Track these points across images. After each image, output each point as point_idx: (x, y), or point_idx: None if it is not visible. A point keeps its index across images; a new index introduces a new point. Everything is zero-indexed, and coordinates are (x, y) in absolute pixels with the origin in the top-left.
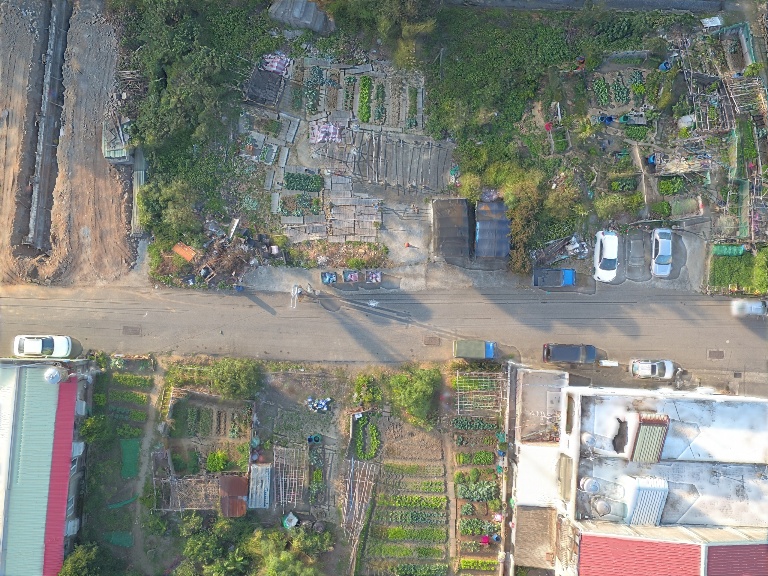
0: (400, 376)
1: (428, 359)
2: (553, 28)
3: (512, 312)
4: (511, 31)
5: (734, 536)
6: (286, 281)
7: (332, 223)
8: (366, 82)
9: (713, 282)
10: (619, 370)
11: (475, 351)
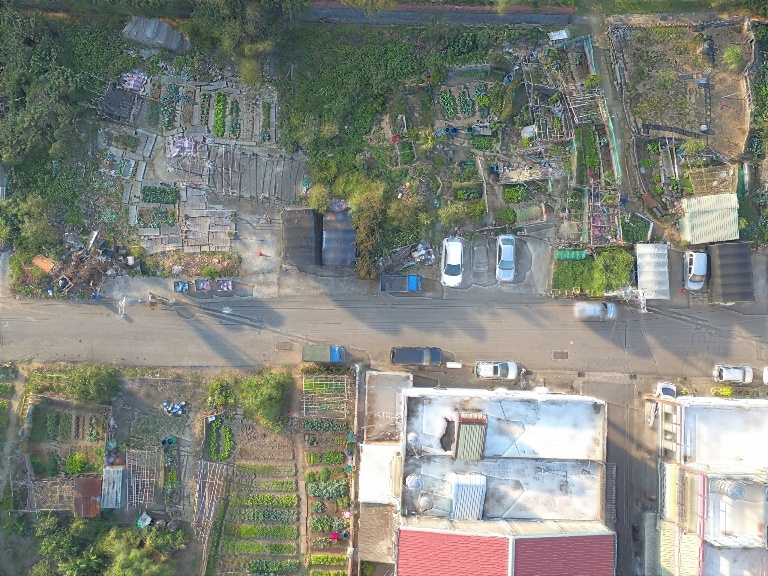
0: (251, 380)
1: (280, 363)
2: (402, 44)
3: (362, 317)
4: (361, 47)
5: (549, 529)
6: (143, 290)
7: (187, 234)
8: (220, 98)
9: (557, 285)
10: (466, 371)
11: (320, 355)
